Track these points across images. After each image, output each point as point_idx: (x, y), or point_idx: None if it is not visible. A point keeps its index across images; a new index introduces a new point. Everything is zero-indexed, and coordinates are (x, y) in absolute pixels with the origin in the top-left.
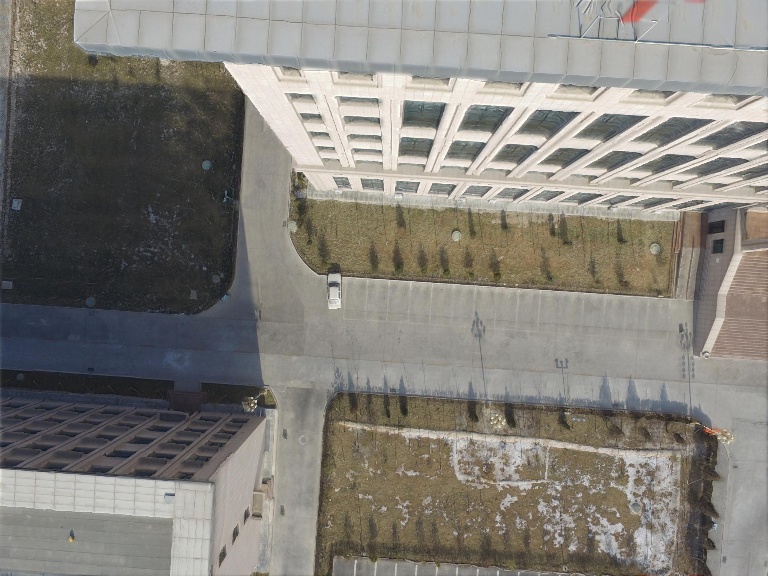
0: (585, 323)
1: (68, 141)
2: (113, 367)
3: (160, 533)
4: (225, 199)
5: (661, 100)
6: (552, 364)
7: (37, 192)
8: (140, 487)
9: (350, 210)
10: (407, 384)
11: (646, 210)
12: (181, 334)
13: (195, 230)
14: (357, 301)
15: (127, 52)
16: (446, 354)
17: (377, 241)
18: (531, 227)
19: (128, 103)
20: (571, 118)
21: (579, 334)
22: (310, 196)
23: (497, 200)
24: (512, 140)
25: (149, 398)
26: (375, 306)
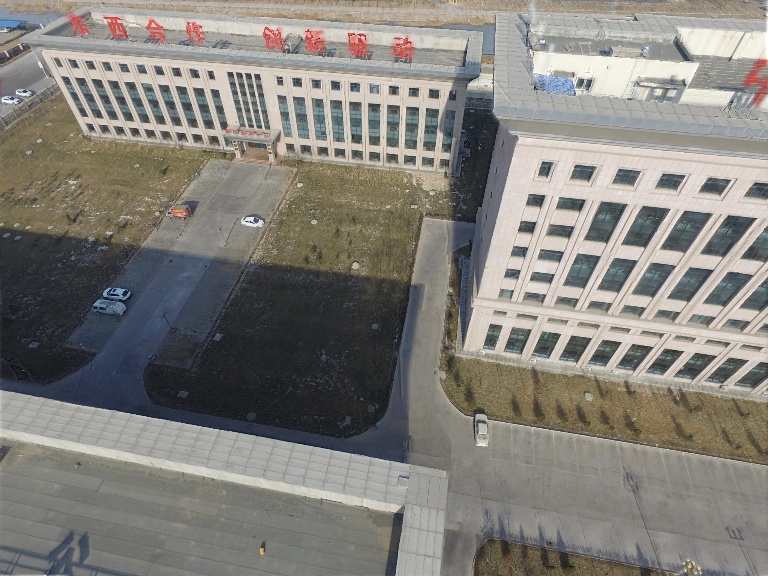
0: (742, 491)
1: (273, 303)
2: None
3: (363, 558)
4: (396, 340)
5: (764, 202)
6: (723, 533)
7: (237, 331)
8: (374, 466)
9: (491, 368)
10: (565, 538)
11: (755, 392)
12: None
13: (358, 369)
14: (503, 443)
15: (512, 114)
16: (602, 508)
17: (517, 394)
18: (655, 396)
19: (324, 286)
20: (705, 222)
21: (740, 502)
22: (458, 354)
23: (618, 372)
24: (657, 256)
25: None
26: (521, 450)
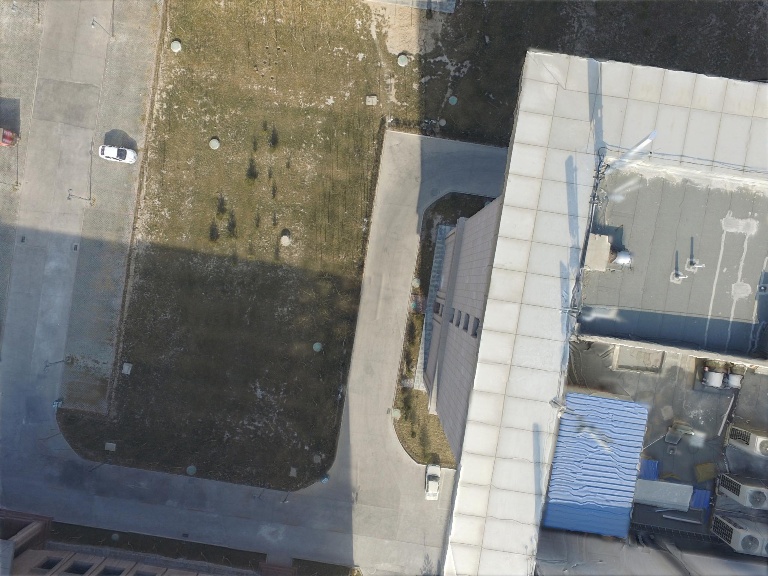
0: None
1: (183, 310)
2: (207, 535)
3: None
4: (340, 396)
5: None
6: None
7: (148, 358)
8: None
9: None
10: None
11: None
12: (277, 509)
13: (300, 409)
14: None
15: None
16: None
17: None
18: None
19: (245, 279)
20: None
21: None
22: (417, 387)
23: None
24: None
25: (240, 569)
26: None
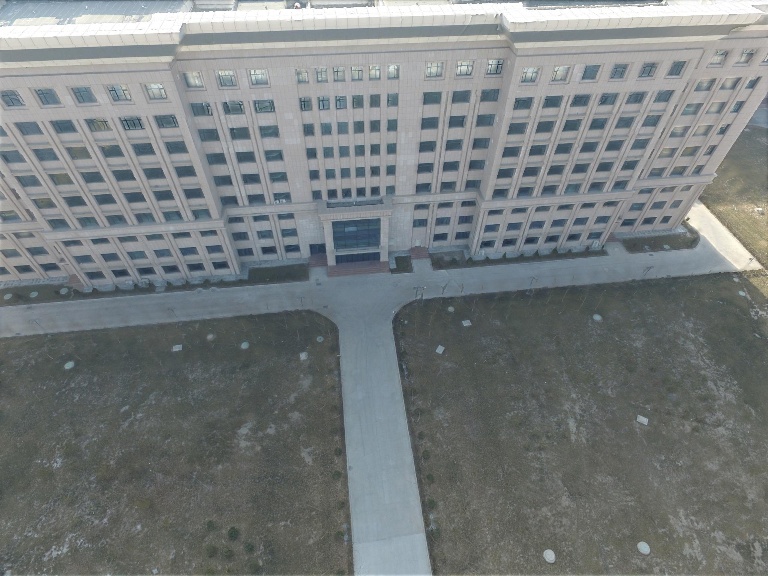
0: None
1: None
2: None
3: None
4: None
5: None
6: None
7: (767, 158)
8: None
9: None
10: None
11: None
12: None
13: None
14: None
15: None
16: None
17: None
18: None
19: (759, 192)
20: None
21: None
22: None
23: None
24: None
25: None
26: None
